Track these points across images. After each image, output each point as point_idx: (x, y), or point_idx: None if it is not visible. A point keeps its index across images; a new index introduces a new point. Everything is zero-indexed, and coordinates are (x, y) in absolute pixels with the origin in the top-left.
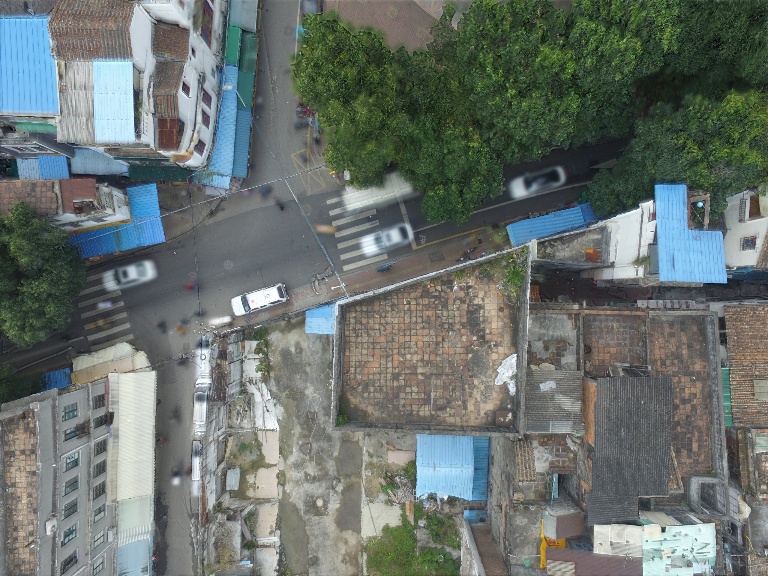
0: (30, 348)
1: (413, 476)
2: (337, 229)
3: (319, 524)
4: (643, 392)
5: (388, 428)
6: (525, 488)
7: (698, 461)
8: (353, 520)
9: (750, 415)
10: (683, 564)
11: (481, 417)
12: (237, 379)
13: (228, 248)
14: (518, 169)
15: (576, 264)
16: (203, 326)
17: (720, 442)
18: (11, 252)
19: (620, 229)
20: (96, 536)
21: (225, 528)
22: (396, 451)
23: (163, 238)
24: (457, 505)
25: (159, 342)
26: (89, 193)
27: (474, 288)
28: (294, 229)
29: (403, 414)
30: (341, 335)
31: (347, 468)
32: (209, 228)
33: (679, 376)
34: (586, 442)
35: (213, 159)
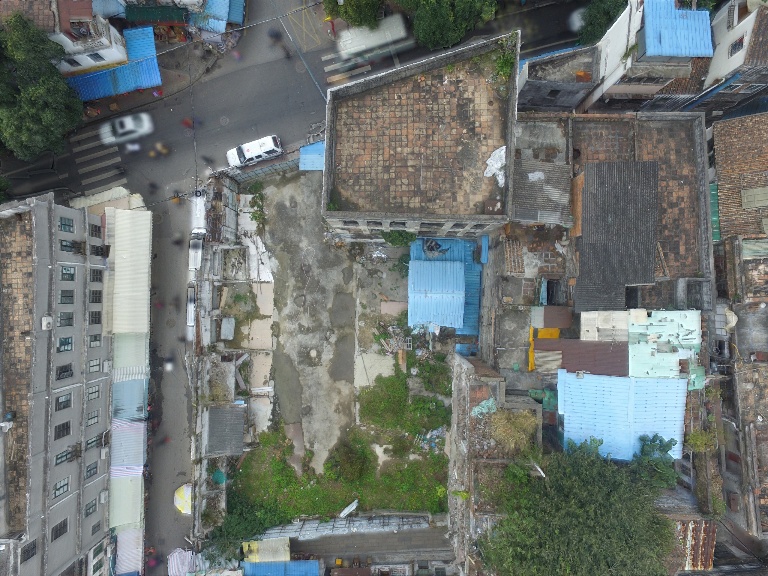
0: (27, 178)
1: (406, 326)
2: (332, 85)
3: (313, 374)
4: (630, 177)
5: (378, 212)
6: (514, 294)
7: (685, 264)
8: (346, 370)
9: (738, 227)
10: (669, 349)
11: (470, 208)
12: (232, 228)
13: (224, 104)
14: (512, 24)
15: (567, 90)
16: (199, 181)
17: (707, 241)
18: (8, 52)
19: (610, 42)
20: (92, 362)
21: (219, 368)
22: (389, 302)
23: (159, 81)
24: (449, 343)
25: (155, 197)
26: (86, 14)
27: (464, 82)
28: (289, 85)
29: (393, 206)
30: (333, 129)
31: (341, 320)
32: (205, 85)
33: (667, 180)
34: (574, 238)
35: (209, 2)
